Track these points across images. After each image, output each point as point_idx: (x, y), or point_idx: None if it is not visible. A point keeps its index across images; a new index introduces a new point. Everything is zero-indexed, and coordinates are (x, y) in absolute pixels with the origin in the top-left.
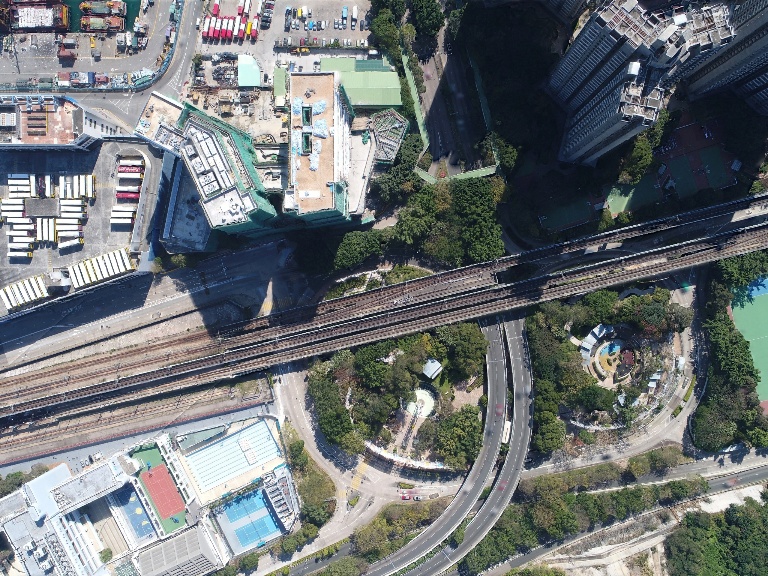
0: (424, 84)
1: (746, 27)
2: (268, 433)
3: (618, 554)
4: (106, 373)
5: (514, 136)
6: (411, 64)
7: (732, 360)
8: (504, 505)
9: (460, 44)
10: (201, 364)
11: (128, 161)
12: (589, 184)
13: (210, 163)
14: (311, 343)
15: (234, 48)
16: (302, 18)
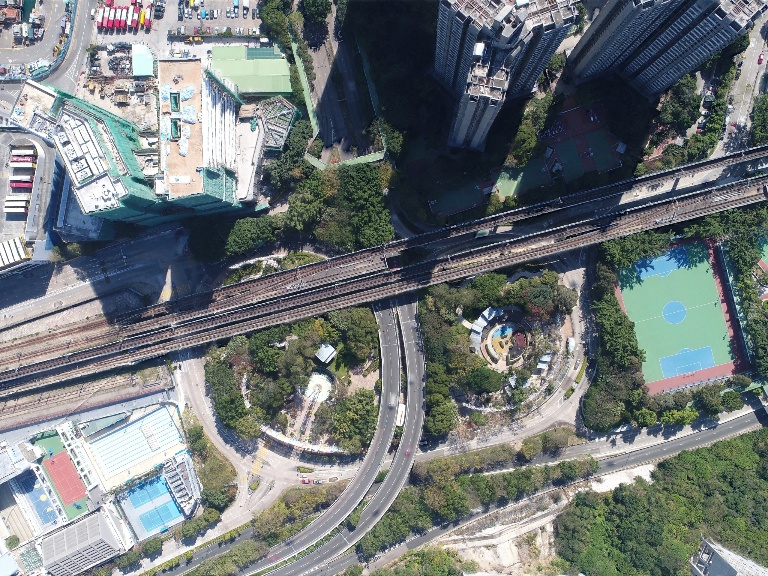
0: (316, 71)
1: (604, 8)
2: (170, 419)
3: (509, 534)
4: (8, 362)
5: (399, 121)
6: (300, 51)
7: (616, 340)
8: (399, 487)
9: (348, 31)
10: (100, 351)
11: (20, 151)
12: (475, 168)
13: (83, 150)
14: (207, 329)
15: (129, 38)
16: (195, 7)
